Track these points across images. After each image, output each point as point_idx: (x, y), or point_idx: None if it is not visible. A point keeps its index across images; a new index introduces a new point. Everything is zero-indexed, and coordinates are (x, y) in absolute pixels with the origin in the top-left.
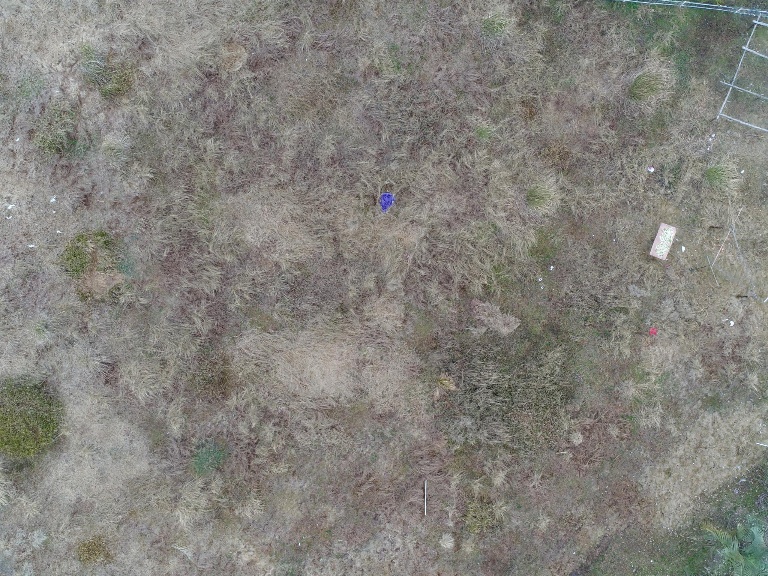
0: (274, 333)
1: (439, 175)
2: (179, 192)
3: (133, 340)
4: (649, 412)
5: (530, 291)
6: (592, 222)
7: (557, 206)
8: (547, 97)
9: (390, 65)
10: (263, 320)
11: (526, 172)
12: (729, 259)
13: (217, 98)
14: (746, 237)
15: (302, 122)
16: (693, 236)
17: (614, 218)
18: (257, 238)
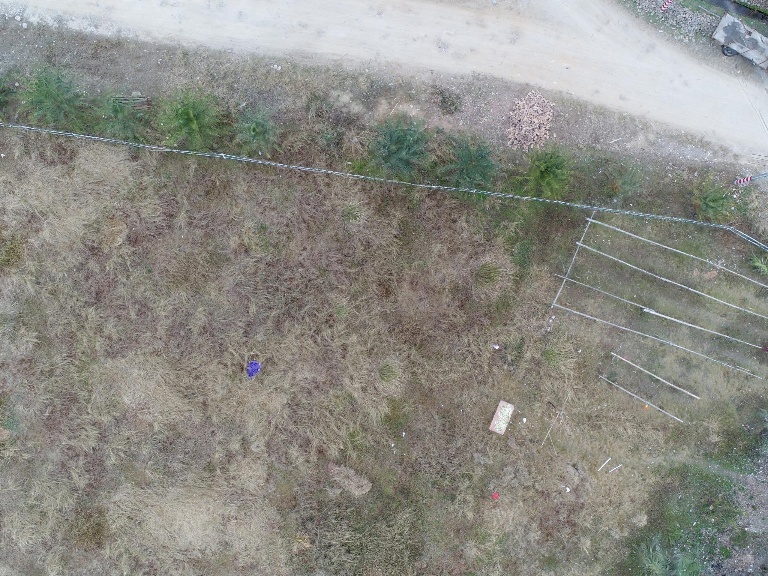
0: (146, 488)
1: (302, 346)
2: (62, 356)
3: (16, 492)
4: (489, 571)
5: (383, 455)
6: (441, 393)
7: (409, 379)
8: (402, 277)
9: (259, 244)
10: (137, 476)
11: (380, 347)
12: (567, 430)
13: (99, 270)
14: (582, 411)
15: (177, 294)
16: (534, 409)
17: (461, 390)
18: (133, 400)
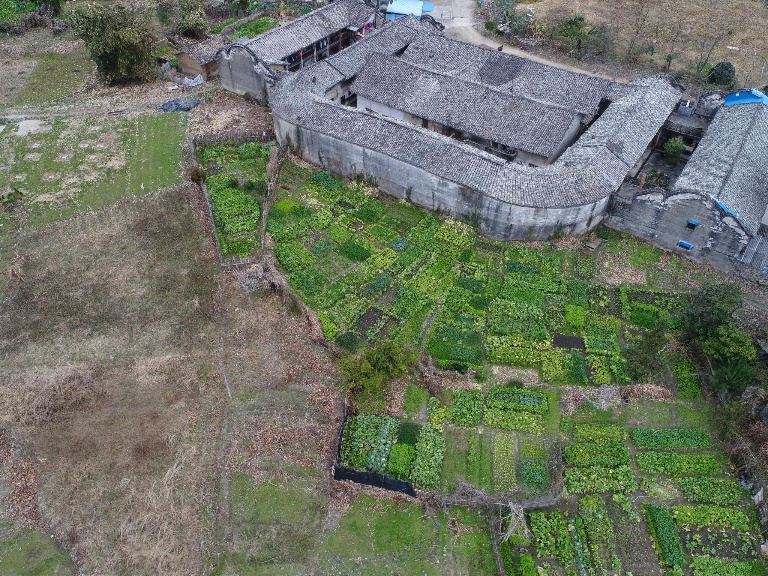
0: None
1: None
2: None
3: None
4: None
5: None
6: None
7: None
8: None
9: None
10: None
11: None
12: None
13: (723, 3)
14: None
15: None
16: None
17: None
18: None
